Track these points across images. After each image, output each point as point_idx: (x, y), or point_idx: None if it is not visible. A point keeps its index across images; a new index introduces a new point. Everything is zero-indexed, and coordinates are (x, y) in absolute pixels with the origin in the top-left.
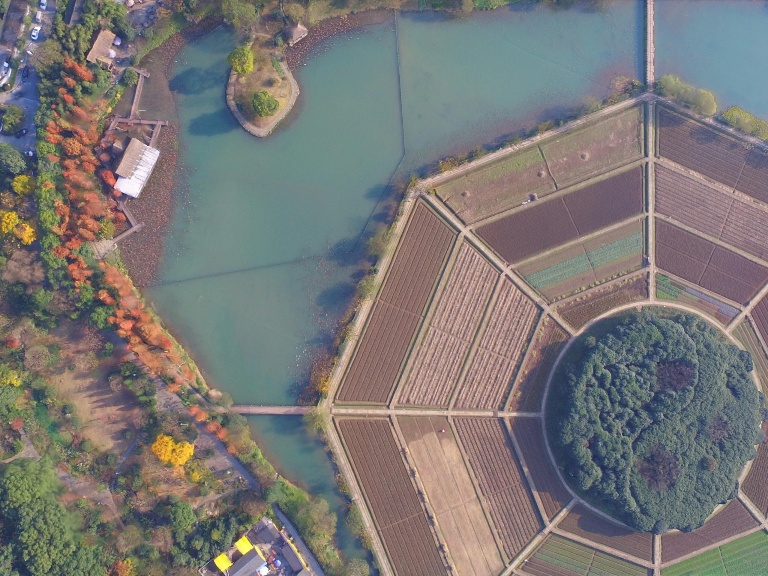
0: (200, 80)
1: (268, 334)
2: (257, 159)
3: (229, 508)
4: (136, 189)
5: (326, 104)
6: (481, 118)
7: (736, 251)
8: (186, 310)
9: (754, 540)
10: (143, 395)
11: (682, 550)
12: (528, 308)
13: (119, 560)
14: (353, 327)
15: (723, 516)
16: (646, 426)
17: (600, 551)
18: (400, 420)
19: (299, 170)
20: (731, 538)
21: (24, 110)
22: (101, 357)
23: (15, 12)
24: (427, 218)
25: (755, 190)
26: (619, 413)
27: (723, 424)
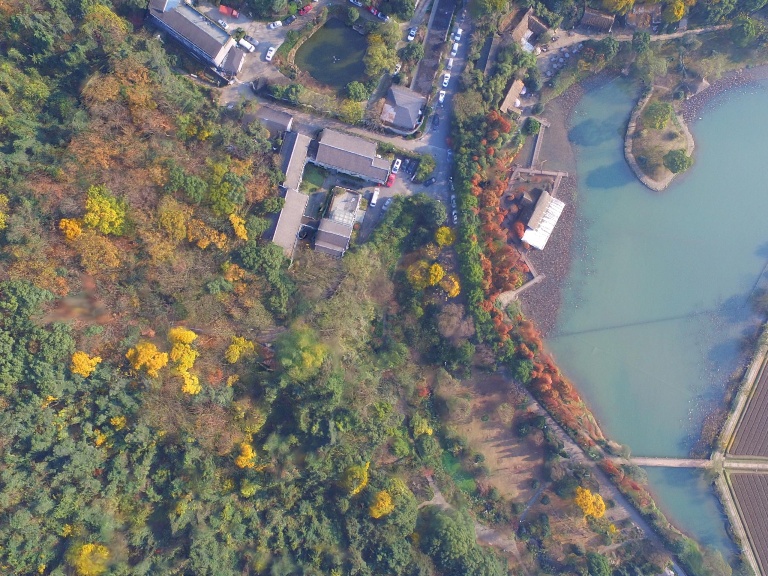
0: (598, 131)
1: (661, 387)
2: (651, 212)
3: None
4: (542, 241)
5: (718, 159)
6: None
7: None
8: (583, 362)
9: None
10: (559, 448)
11: None
12: None
13: None
14: (745, 383)
15: None
16: None
17: None
18: None
19: (692, 225)
20: None
21: (433, 158)
22: (517, 409)
23: (429, 59)
24: None
25: None
26: None
27: None
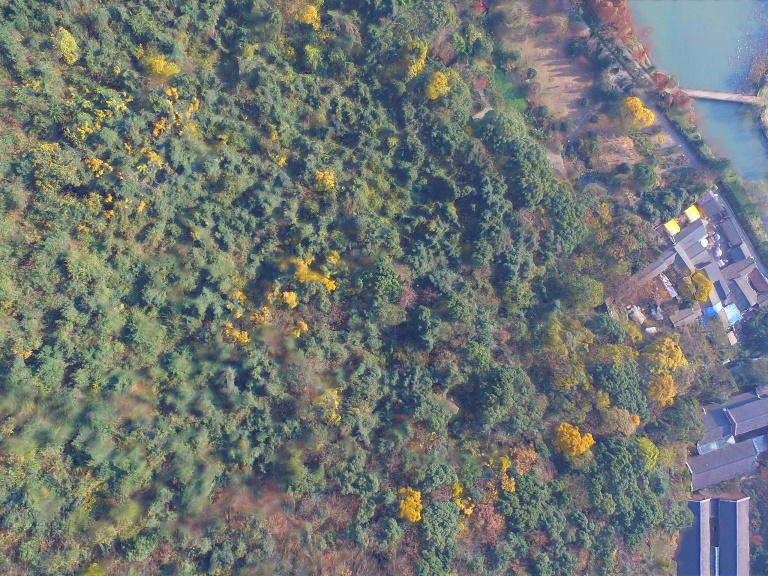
0: None
1: (712, 25)
2: None
3: (673, 182)
4: None
5: None
6: None
7: None
8: None
9: None
10: None
11: None
12: None
13: (597, 203)
14: None
15: None
16: None
17: None
18: None
19: None
20: None
21: None
22: (571, 22)
23: None
24: None
25: None
26: None
27: None
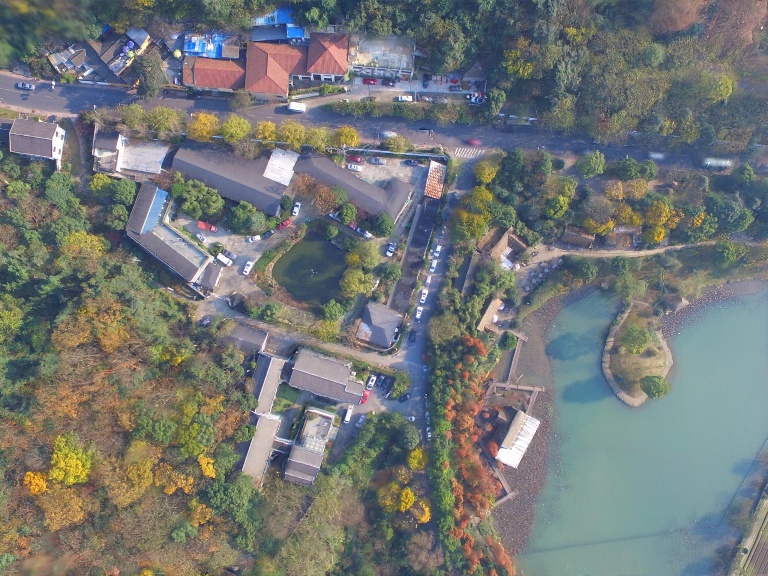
0: (576, 345)
1: None
2: (627, 427)
3: None
4: (516, 460)
5: (696, 373)
6: None
7: None
8: None
9: None
10: None
11: None
12: None
13: None
14: None
15: None
16: None
17: None
18: None
19: (669, 441)
20: None
21: (408, 374)
22: None
23: (407, 276)
24: None
25: None
26: None
27: None
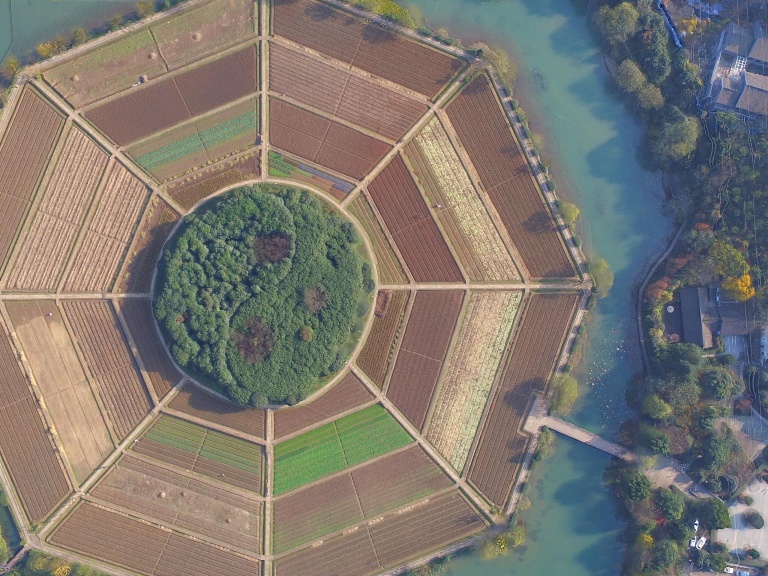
0: None
1: None
2: None
3: None
4: None
5: None
6: (92, 2)
7: (352, 127)
8: None
9: (370, 414)
10: None
11: (295, 426)
12: (138, 190)
13: None
14: None
15: (337, 391)
16: (244, 299)
17: (212, 429)
18: (7, 305)
19: None
20: (345, 412)
21: None
22: None
23: None
24: (35, 103)
25: (372, 65)
26: (217, 287)
27: (320, 294)
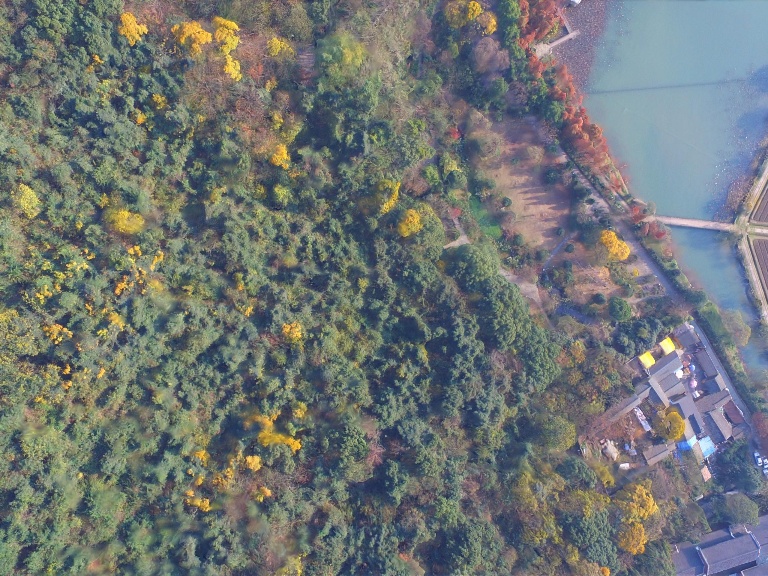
0: None
1: (689, 151)
2: None
3: (649, 312)
4: None
5: None
6: None
7: None
8: (613, 120)
9: None
10: None
11: None
12: None
13: (570, 341)
14: None
15: None
16: None
17: None
18: None
19: None
20: None
21: None
22: (547, 152)
23: None
24: None
25: None
26: None
27: None
